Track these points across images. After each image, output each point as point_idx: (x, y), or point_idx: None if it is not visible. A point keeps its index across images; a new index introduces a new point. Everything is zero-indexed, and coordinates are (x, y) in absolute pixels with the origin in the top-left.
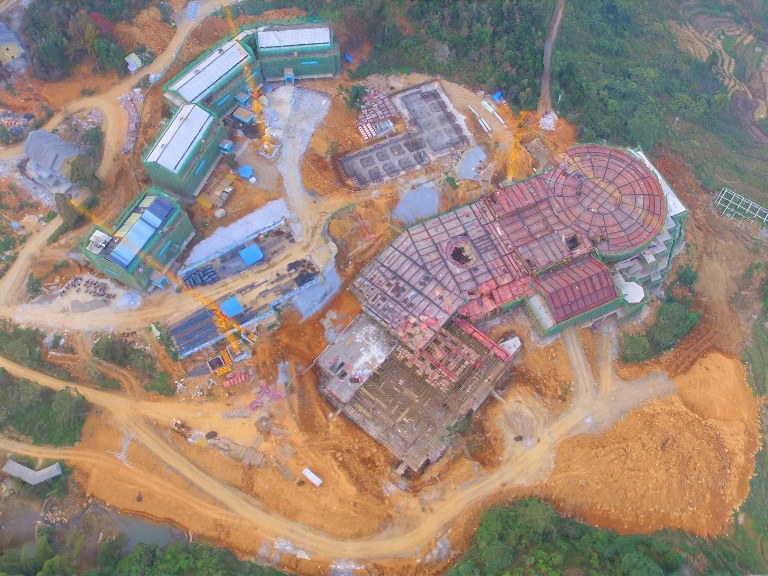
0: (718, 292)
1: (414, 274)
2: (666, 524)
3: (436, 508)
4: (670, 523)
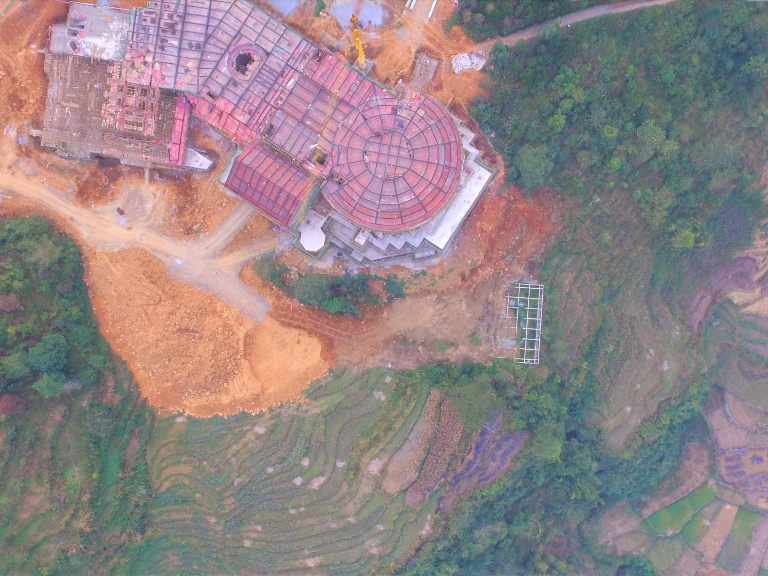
0: (399, 323)
1: (195, 32)
2: (129, 361)
3: (18, 176)
4: (132, 363)
